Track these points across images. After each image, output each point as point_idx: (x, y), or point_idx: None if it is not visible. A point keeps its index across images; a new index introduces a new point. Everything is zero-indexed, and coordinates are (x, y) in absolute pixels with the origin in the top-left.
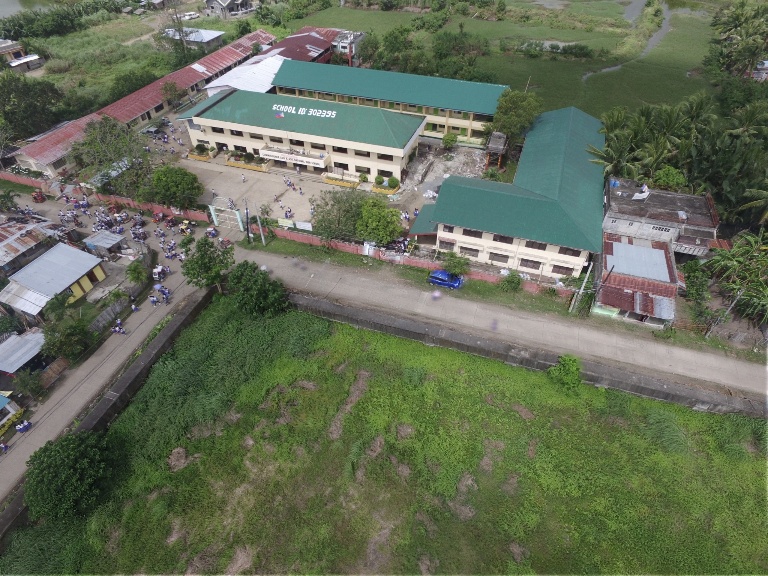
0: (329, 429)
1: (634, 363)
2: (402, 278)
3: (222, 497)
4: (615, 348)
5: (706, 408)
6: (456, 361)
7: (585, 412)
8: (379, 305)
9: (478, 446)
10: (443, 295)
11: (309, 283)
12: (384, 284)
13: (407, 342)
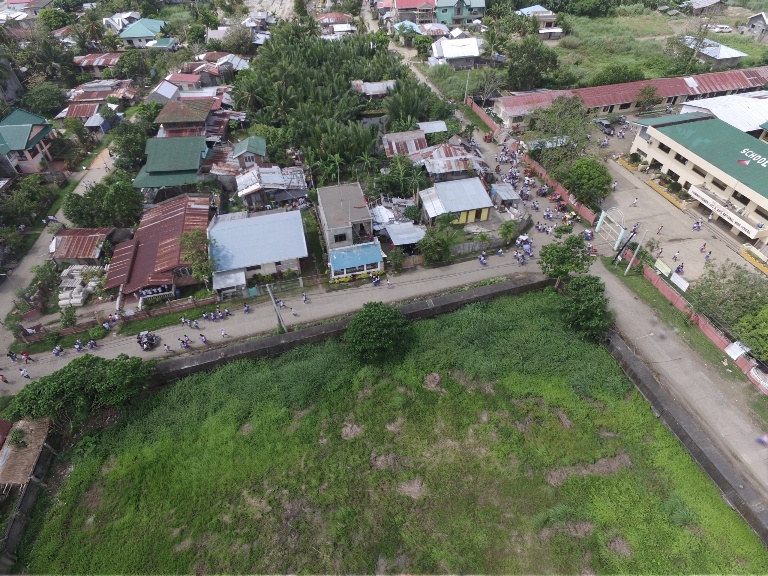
0: (553, 472)
1: None
2: (758, 413)
3: (436, 435)
4: None
5: None
6: (751, 550)
7: None
8: (703, 416)
9: None
10: None
11: (643, 338)
12: (728, 401)
13: (703, 476)
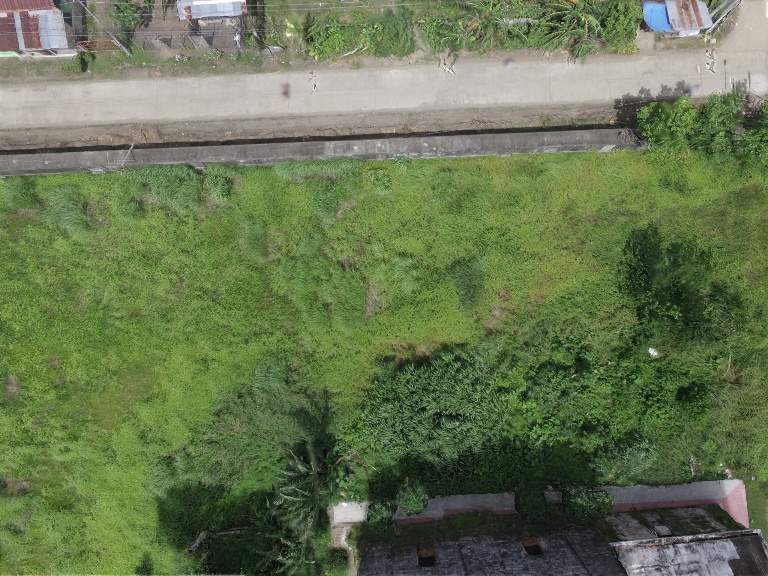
0: None
1: (45, 126)
2: None
3: None
4: (24, 110)
5: (101, 170)
6: None
7: None
8: None
9: None
10: None
11: None
12: None
13: None
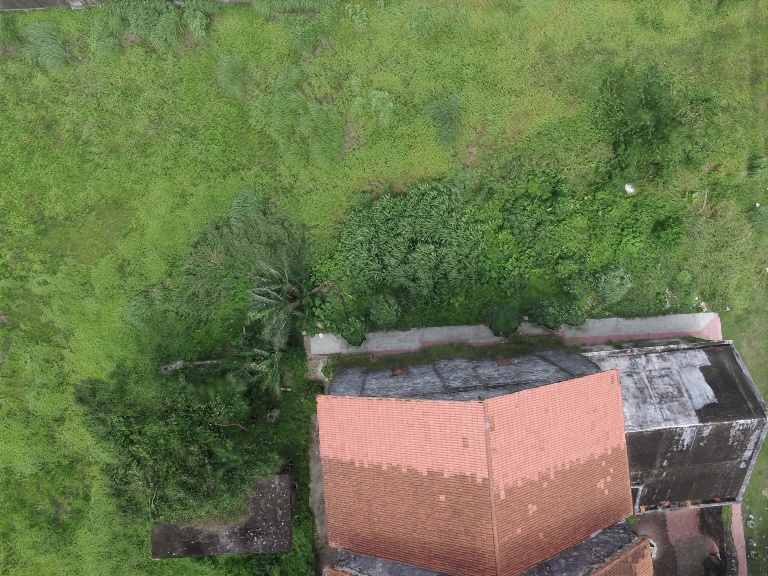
0: None
1: None
2: None
3: None
4: None
5: (80, 4)
6: None
7: None
8: None
9: None
10: None
11: None
12: None
13: None
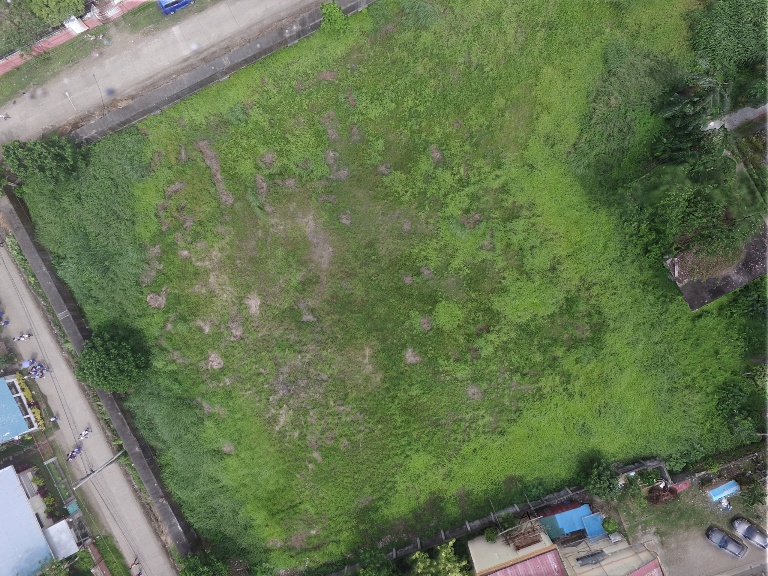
0: (222, 201)
1: None
2: (142, 28)
3: (207, 291)
4: None
5: None
6: (255, 75)
7: (365, 40)
8: (153, 74)
9: (319, 127)
10: (192, 17)
11: (74, 104)
12: (135, 48)
13: (208, 90)
